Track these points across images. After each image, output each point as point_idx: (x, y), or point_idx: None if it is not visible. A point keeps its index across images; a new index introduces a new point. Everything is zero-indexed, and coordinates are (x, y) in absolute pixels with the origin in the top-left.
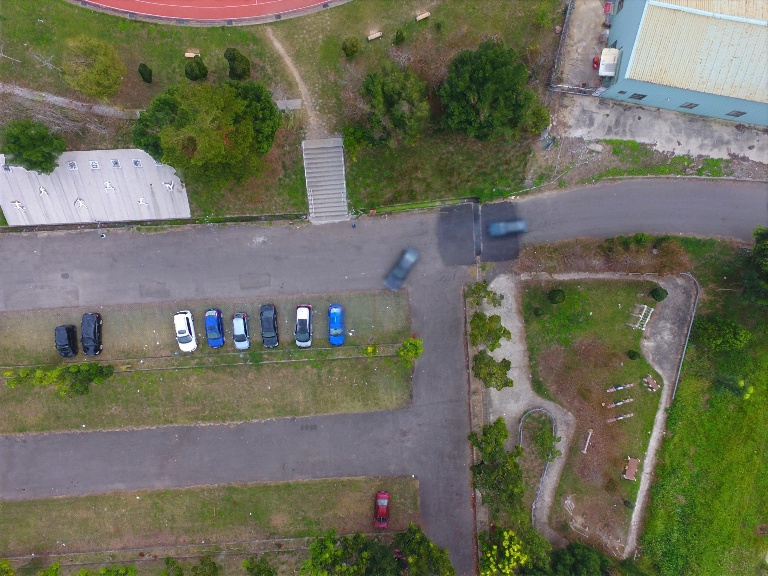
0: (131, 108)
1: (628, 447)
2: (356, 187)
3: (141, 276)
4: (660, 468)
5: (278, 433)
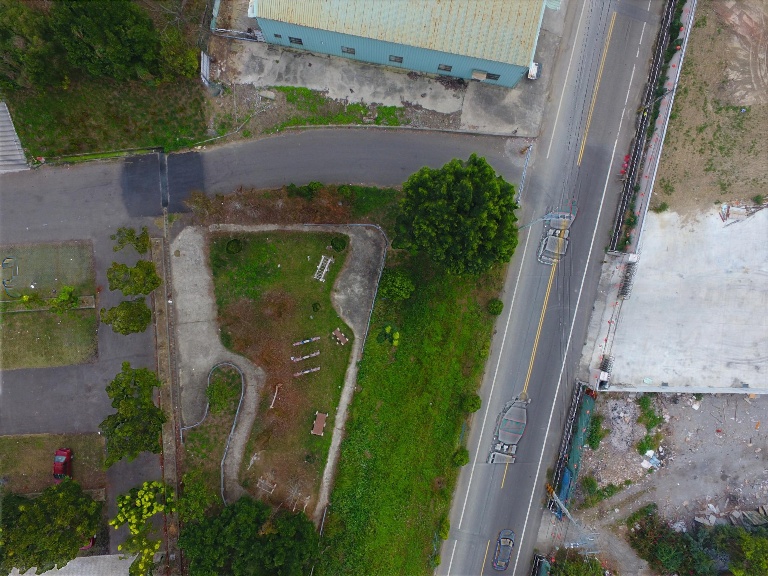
0: None
1: (318, 402)
2: (29, 134)
3: None
4: (349, 423)
5: None
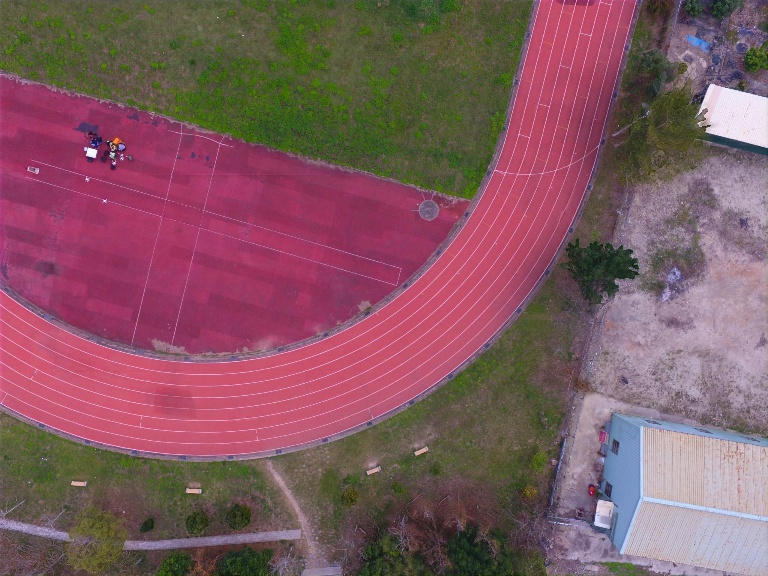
0: (133, 539)
1: None
2: None
3: None
4: None
5: None
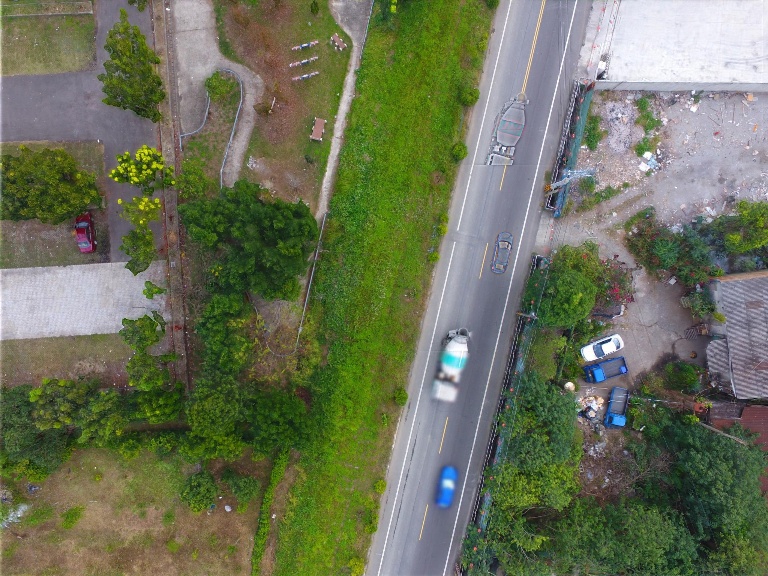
0: None
1: (316, 109)
2: None
3: None
4: (348, 129)
5: None
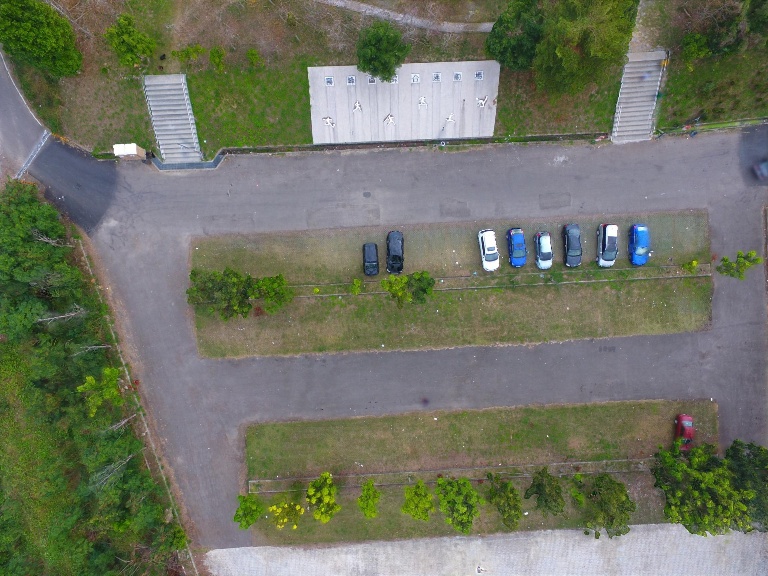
0: (454, 21)
1: None
2: (665, 104)
3: (442, 195)
4: None
5: (576, 354)
